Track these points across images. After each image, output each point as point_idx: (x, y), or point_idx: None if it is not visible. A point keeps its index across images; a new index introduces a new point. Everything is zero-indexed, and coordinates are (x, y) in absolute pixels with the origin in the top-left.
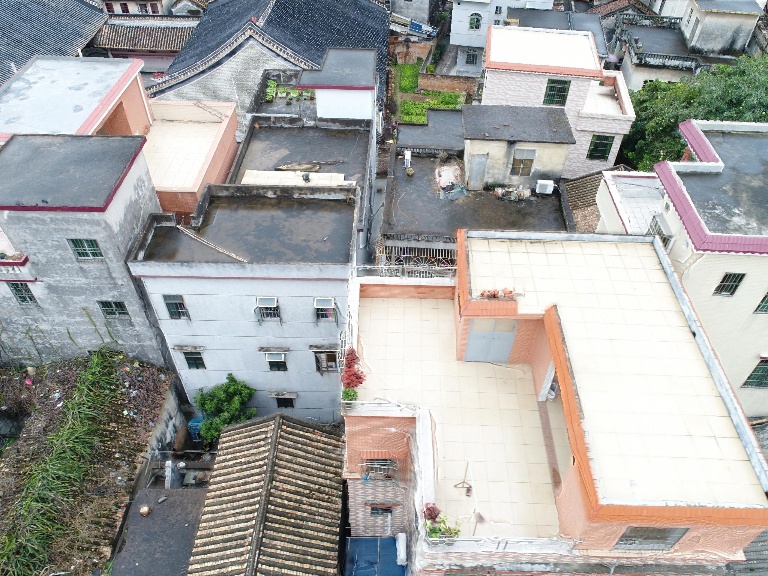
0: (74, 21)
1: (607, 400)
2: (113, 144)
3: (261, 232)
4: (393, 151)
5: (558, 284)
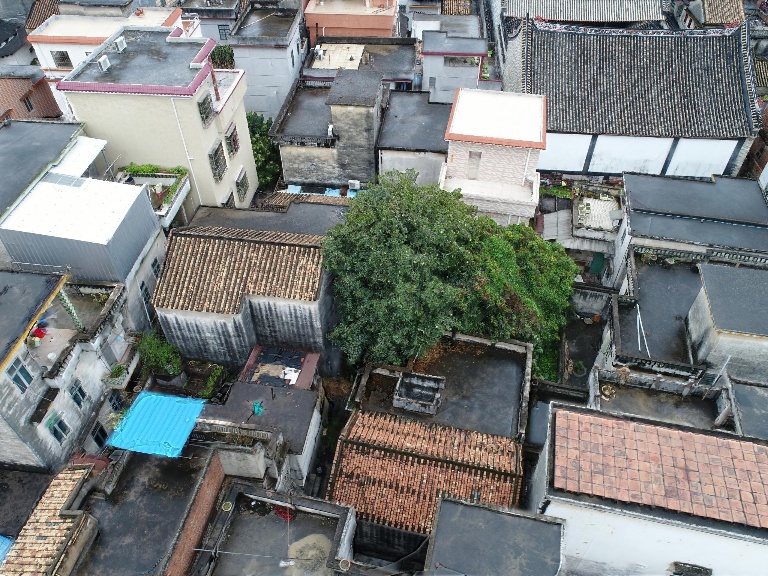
0: (632, 6)
1: (86, 24)
2: None
3: (269, 26)
4: None
5: (140, 23)
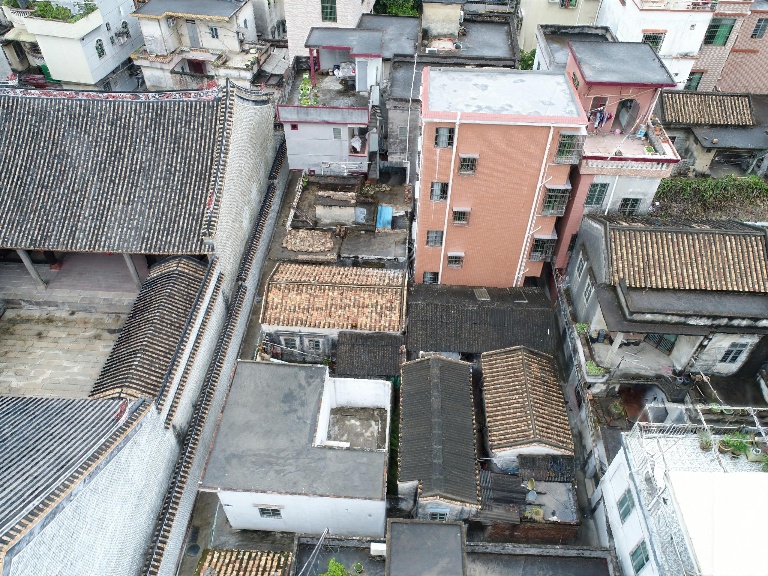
0: None
1: None
2: (582, 49)
3: None
4: (427, 53)
5: None
